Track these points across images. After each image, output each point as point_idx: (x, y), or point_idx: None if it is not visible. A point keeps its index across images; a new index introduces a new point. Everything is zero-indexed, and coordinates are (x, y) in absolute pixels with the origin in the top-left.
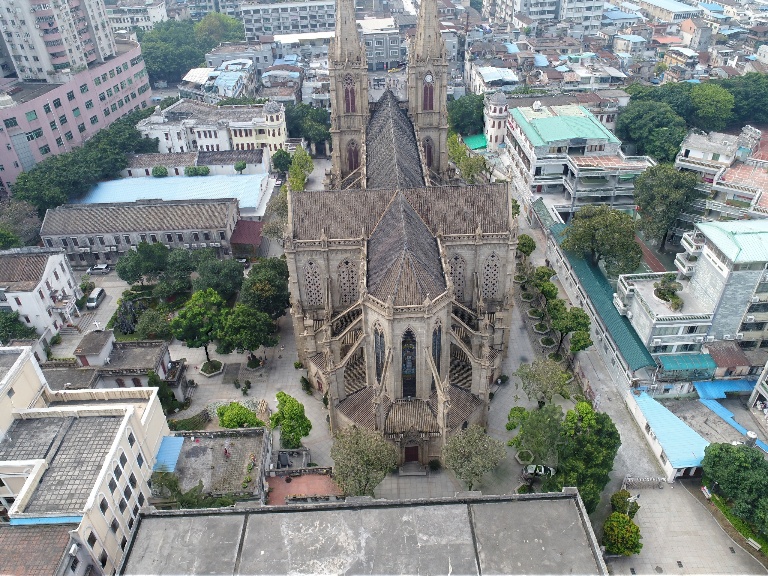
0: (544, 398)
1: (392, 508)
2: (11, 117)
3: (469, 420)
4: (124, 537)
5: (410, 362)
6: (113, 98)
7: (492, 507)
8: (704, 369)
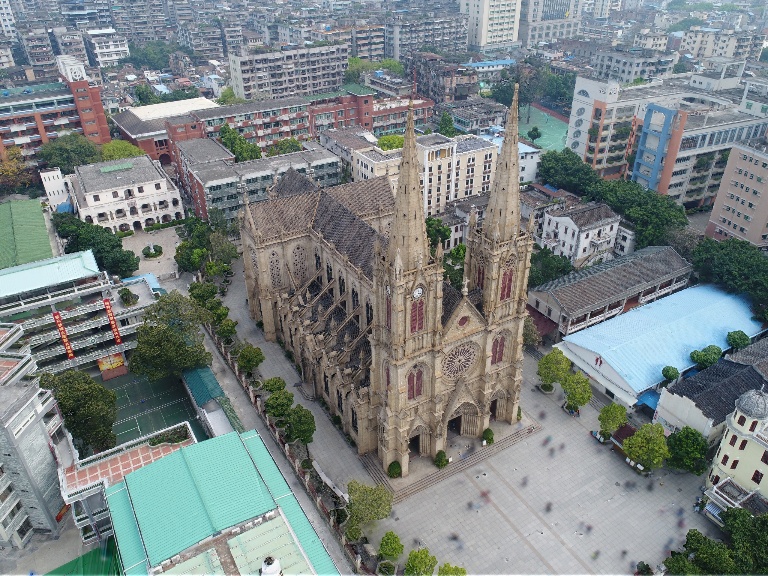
0: (222, 302)
1: None
2: None
3: None
4: None
5: None
6: None
7: None
8: None
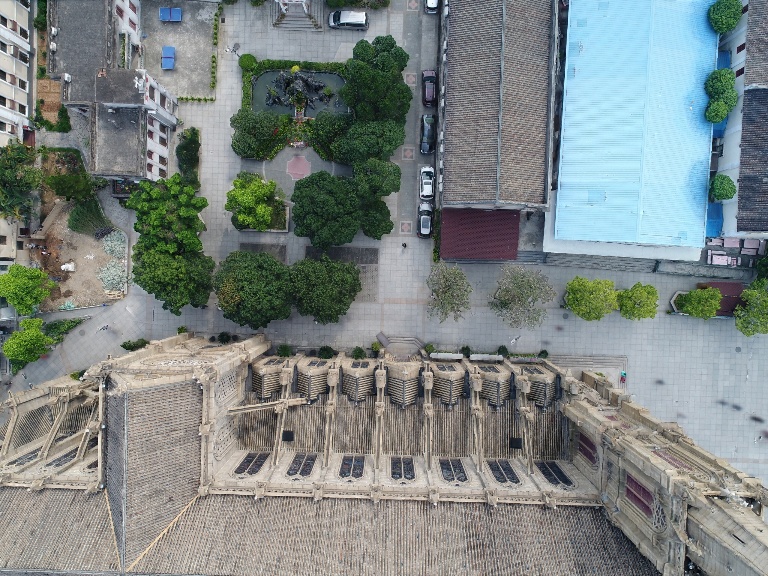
0: None
1: None
2: None
3: None
4: None
5: None
6: None
7: None
8: None
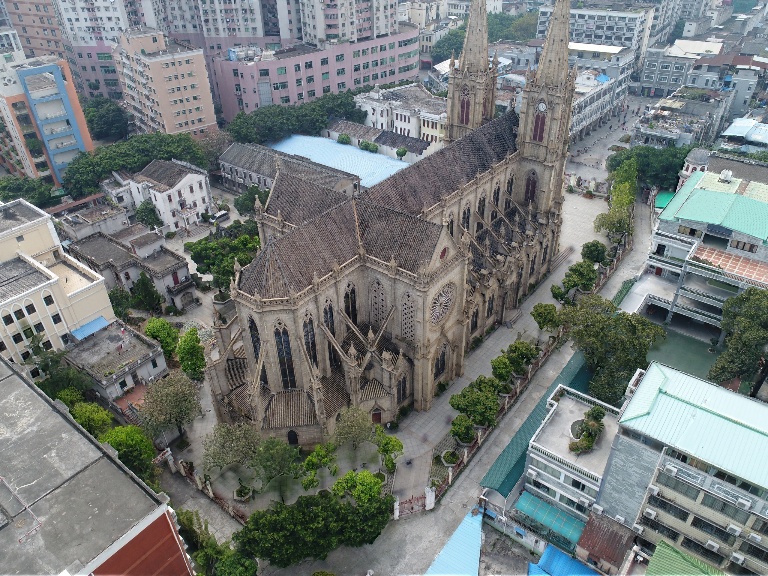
0: (409, 464)
1: (69, 424)
2: (266, 68)
3: (300, 432)
4: (11, 359)
5: (259, 349)
6: (368, 71)
7: (111, 468)
8: (562, 536)
